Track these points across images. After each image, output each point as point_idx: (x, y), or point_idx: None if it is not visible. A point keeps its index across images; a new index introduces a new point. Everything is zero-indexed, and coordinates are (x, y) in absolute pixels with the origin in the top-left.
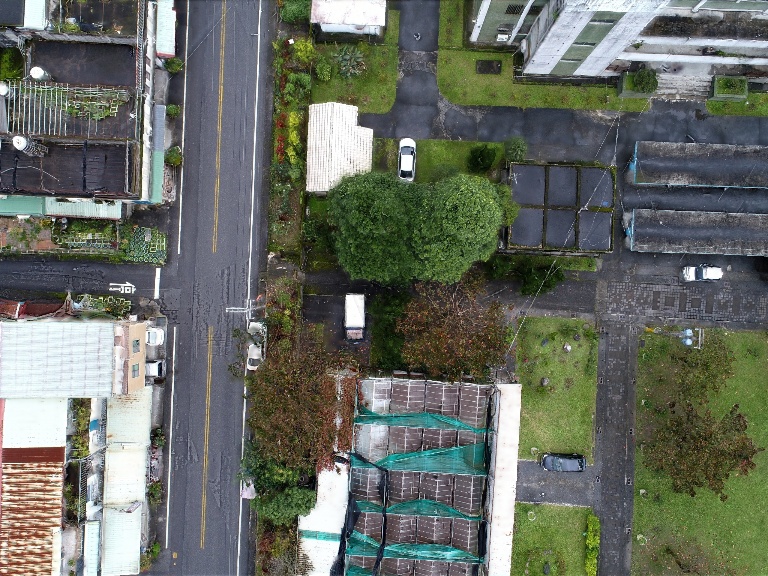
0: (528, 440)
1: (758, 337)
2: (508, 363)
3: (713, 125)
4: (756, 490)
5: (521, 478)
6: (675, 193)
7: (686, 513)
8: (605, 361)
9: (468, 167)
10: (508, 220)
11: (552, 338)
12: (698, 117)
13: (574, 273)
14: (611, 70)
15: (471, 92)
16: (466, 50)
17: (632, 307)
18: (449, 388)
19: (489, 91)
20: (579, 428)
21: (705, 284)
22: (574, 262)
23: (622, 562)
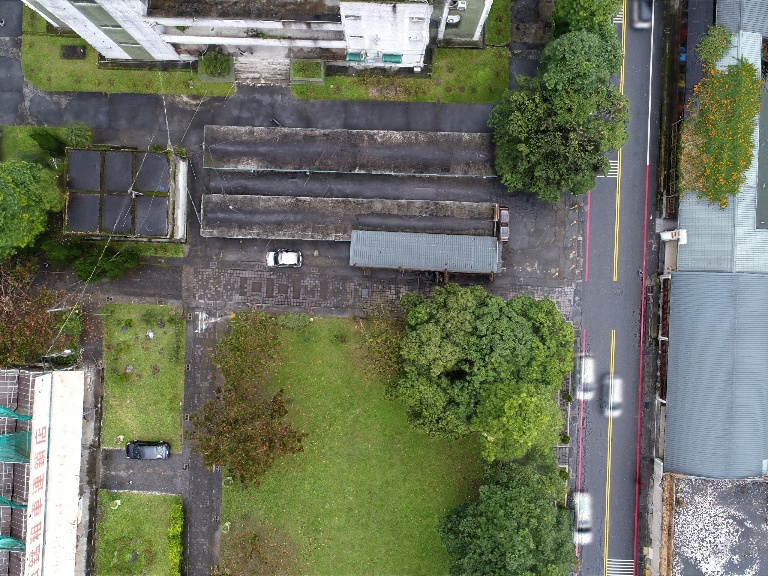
0: (115, 428)
1: (346, 322)
2: (95, 351)
3: (298, 109)
4: (343, 476)
5: (109, 466)
6: (261, 178)
7: (274, 500)
8: (192, 348)
9: (49, 153)
10: (45, 205)
11: (125, 325)
12: (283, 101)
13: (160, 259)
14: (187, 54)
15: (55, 78)
16: (50, 35)
17: (219, 293)
18: (4, 376)
19: (74, 77)
20: (167, 415)
21: (292, 269)
22: (158, 248)
23: (211, 550)
